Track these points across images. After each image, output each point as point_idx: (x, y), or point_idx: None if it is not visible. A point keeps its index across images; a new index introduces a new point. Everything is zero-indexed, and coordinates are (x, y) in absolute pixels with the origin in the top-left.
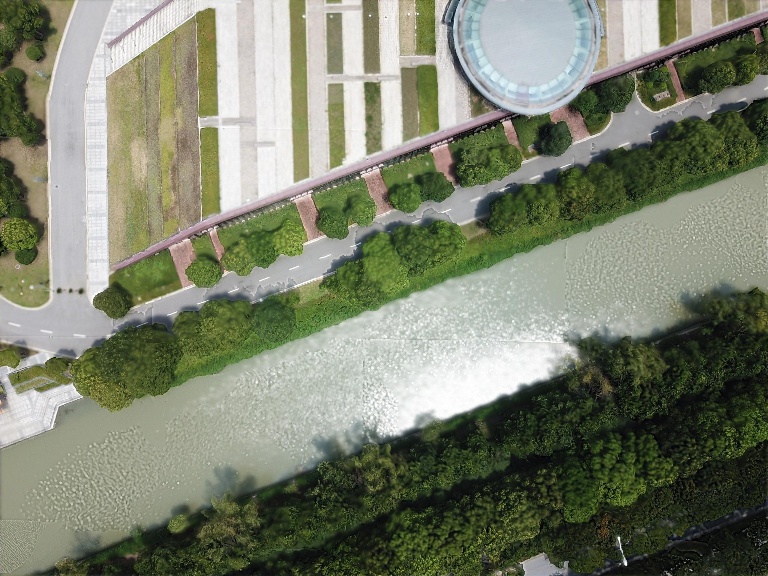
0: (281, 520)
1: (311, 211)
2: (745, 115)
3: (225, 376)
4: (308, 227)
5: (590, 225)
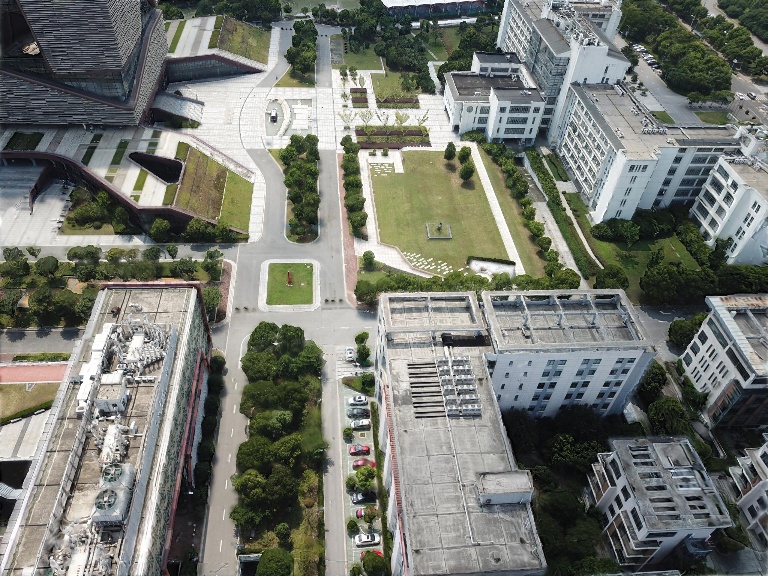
0: None
1: None
2: None
3: None
4: None
5: None
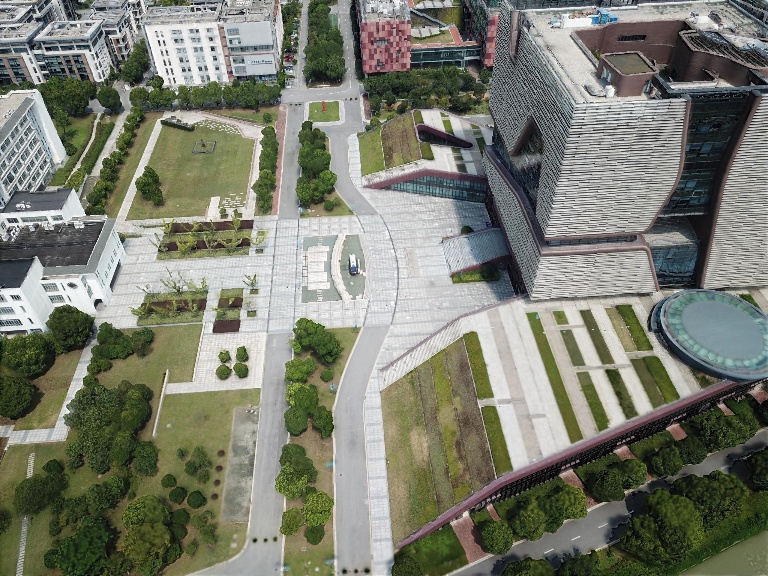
0: None
1: (577, 484)
2: None
3: None
4: None
5: None
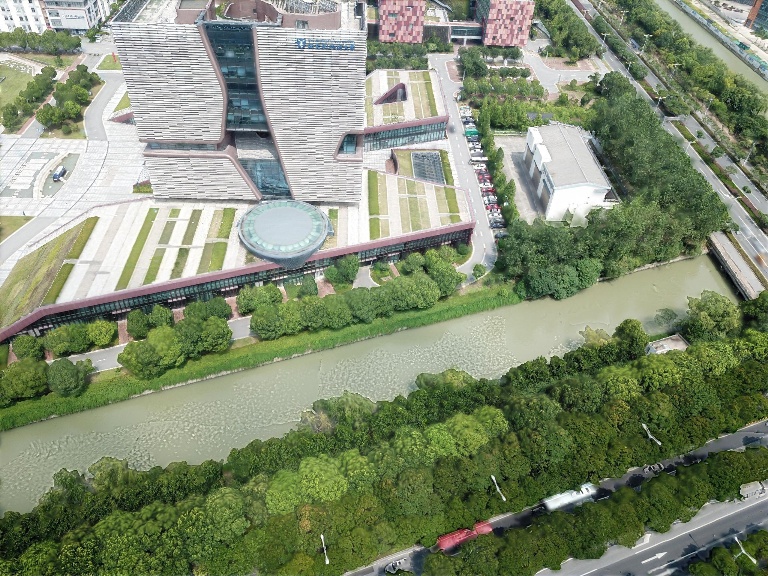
0: None
1: None
2: (429, 274)
3: (12, 450)
4: (122, 336)
5: (333, 341)
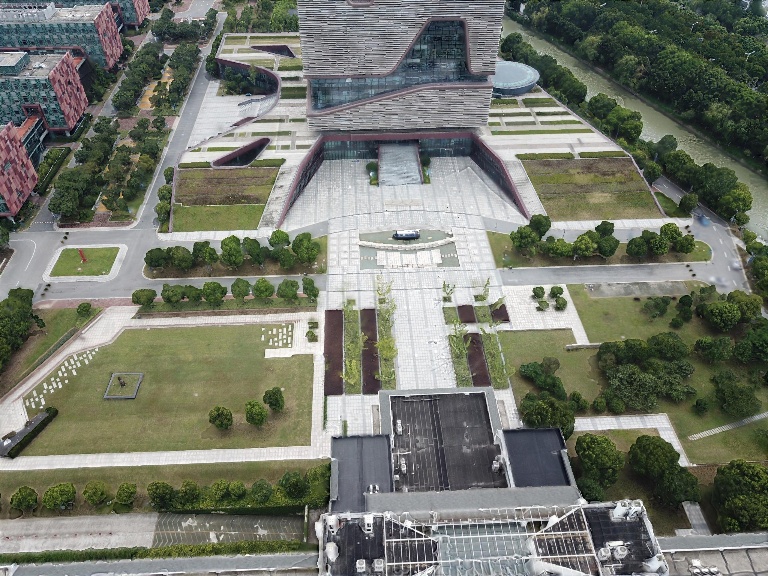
0: (767, 138)
1: None
2: None
3: None
4: None
5: None
